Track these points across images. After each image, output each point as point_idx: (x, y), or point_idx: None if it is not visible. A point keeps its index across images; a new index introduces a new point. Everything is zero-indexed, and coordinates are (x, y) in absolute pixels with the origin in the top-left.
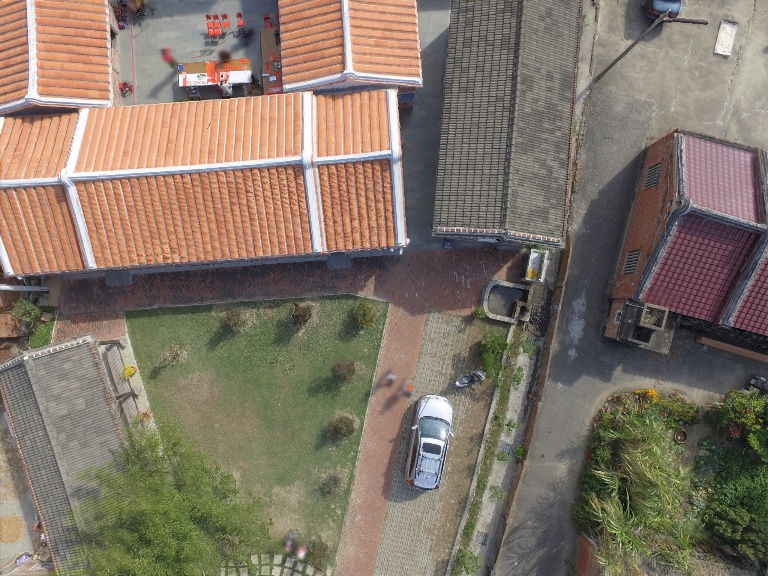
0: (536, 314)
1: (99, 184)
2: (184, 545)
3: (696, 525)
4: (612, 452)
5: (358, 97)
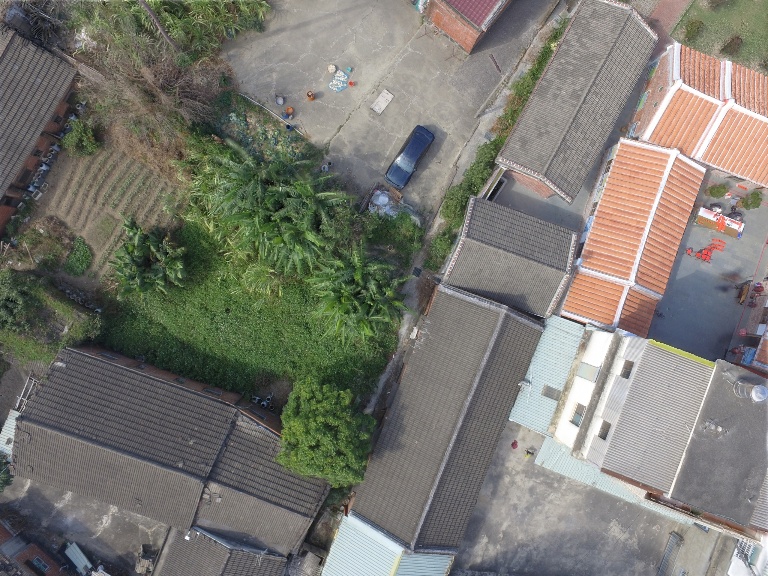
0: None
1: None
2: None
3: None
4: None
5: (667, 144)
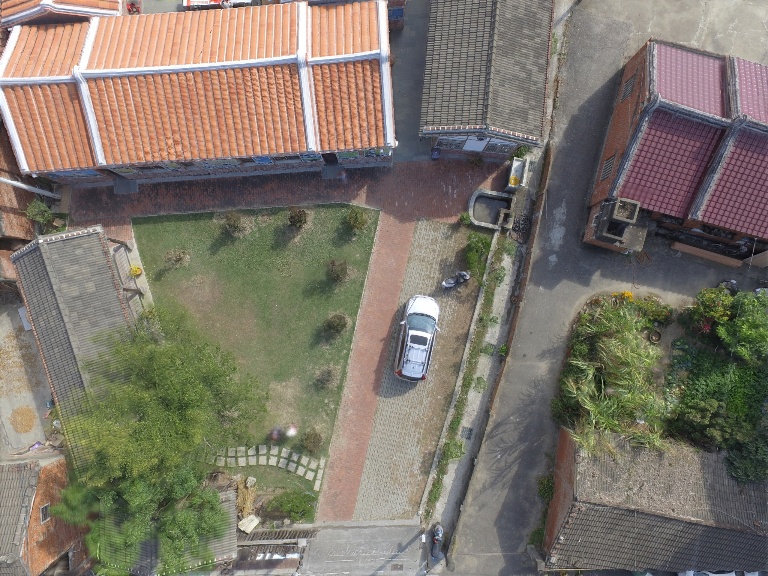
0: (519, 222)
1: (109, 81)
2: (186, 414)
3: (669, 420)
4: (589, 348)
5: (350, 7)
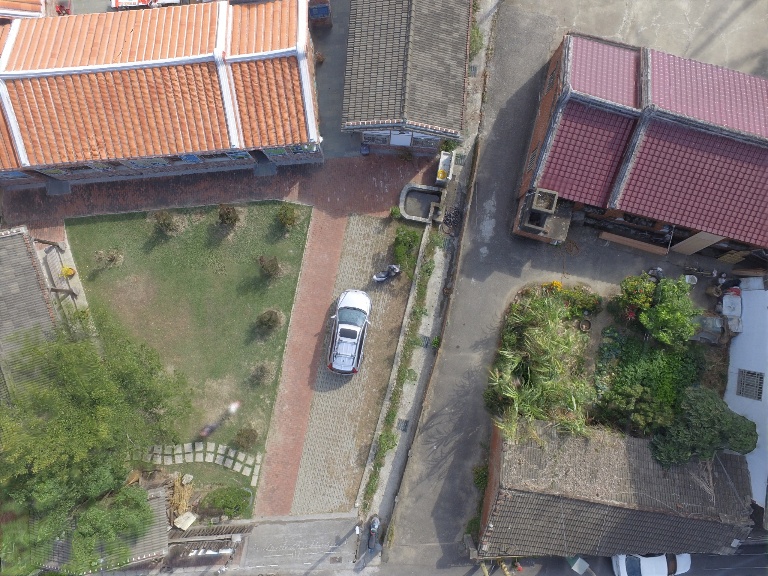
0: (450, 215)
1: (27, 82)
2: (110, 412)
3: (601, 407)
4: (519, 337)
5: (271, 6)
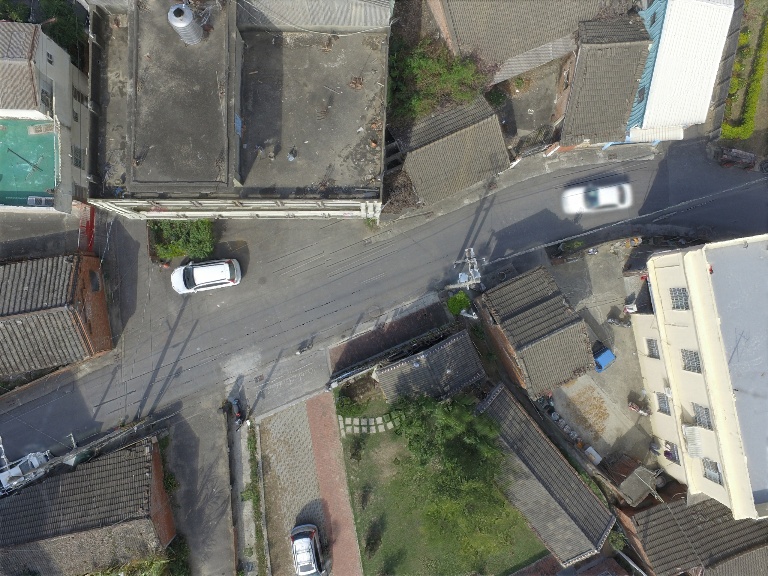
0: None
1: None
2: None
3: None
4: None
5: None
